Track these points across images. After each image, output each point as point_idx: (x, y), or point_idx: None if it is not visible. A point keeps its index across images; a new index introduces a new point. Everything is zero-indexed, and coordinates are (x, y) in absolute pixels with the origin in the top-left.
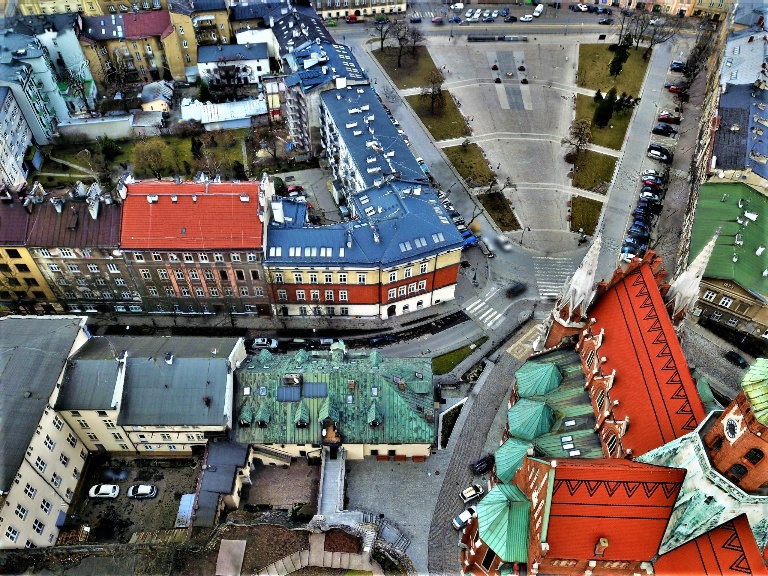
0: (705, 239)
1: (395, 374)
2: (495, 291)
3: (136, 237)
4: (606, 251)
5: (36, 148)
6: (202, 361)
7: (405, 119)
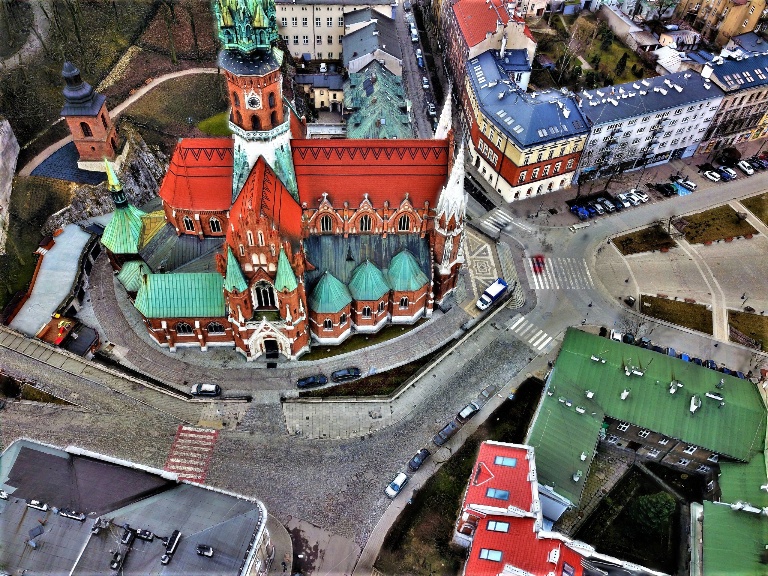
0: (631, 351)
1: (387, 120)
2: (527, 229)
3: (460, 6)
4: (622, 322)
5: (578, 4)
6: (376, 43)
7: (766, 181)
